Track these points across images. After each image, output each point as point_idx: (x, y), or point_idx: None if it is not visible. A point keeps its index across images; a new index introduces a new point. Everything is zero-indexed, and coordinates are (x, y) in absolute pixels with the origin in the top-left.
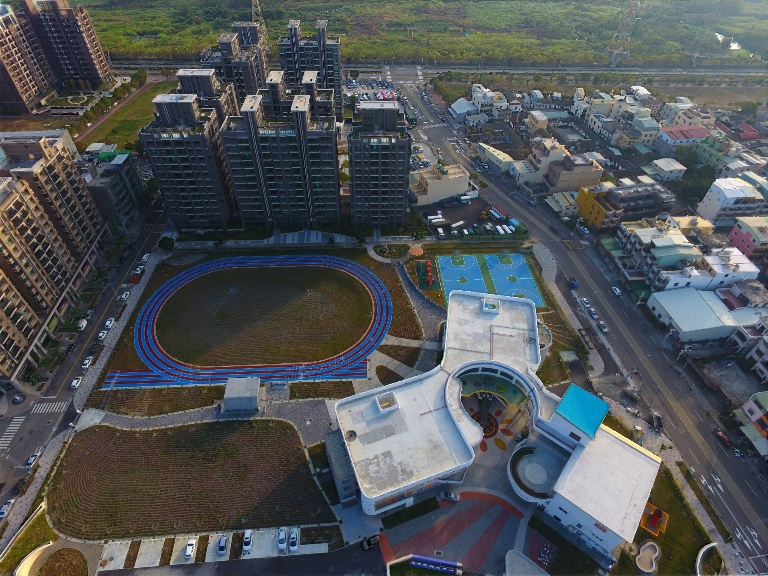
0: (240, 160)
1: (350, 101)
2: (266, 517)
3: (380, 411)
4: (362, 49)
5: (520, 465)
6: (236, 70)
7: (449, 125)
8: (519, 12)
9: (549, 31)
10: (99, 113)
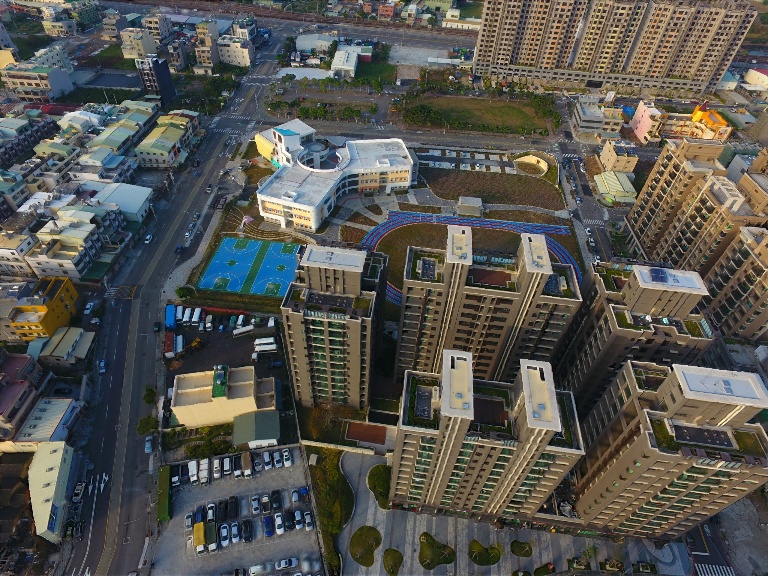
0: None
1: None
2: (446, 171)
3: None
4: None
5: None
6: None
7: None
8: None
9: None
10: None
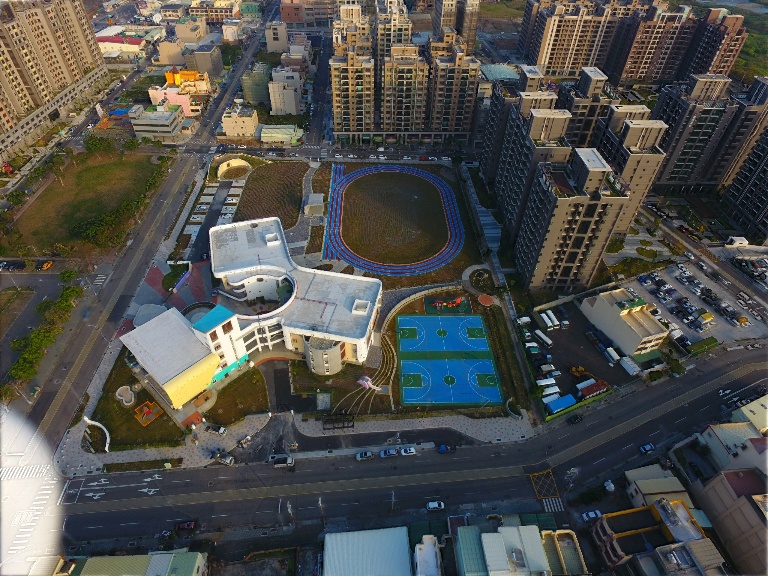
0: None
1: None
2: None
3: (267, 236)
4: None
5: (209, 310)
6: (679, 108)
7: None
8: None
9: None
10: None
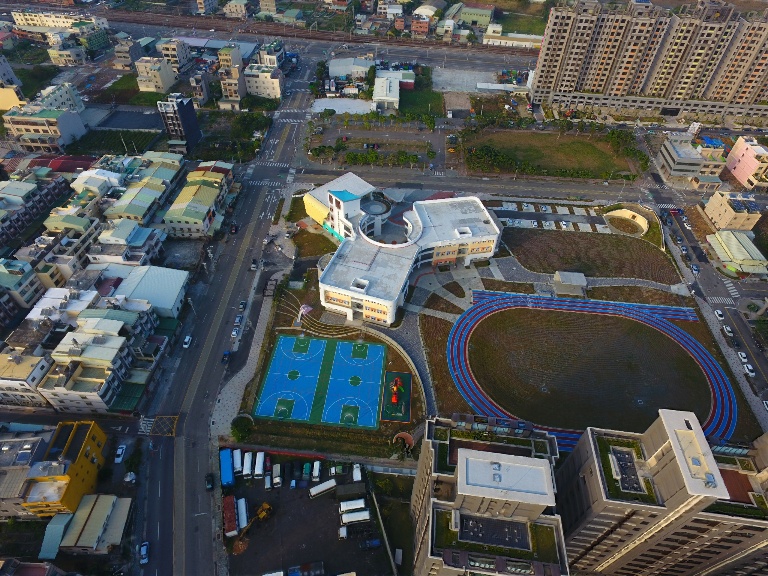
0: None
1: None
2: (528, 231)
3: None
4: None
5: None
6: None
7: None
8: None
9: None
10: None
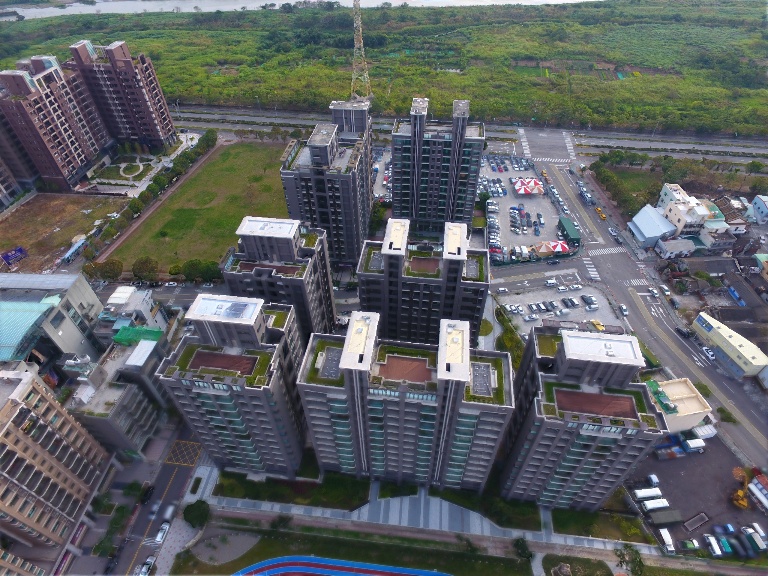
0: (328, 415)
1: (480, 199)
2: None
3: None
4: (484, 96)
5: None
6: (330, 184)
7: (629, 251)
8: (685, 42)
9: (740, 76)
10: (150, 198)
